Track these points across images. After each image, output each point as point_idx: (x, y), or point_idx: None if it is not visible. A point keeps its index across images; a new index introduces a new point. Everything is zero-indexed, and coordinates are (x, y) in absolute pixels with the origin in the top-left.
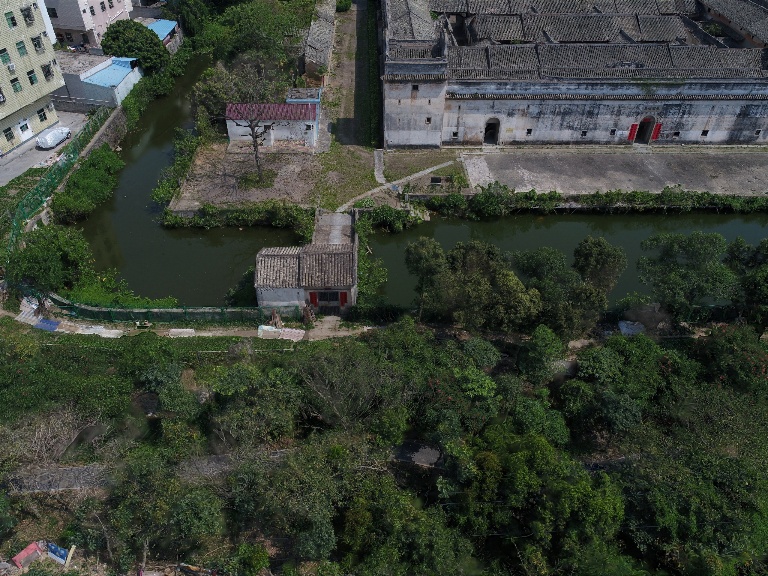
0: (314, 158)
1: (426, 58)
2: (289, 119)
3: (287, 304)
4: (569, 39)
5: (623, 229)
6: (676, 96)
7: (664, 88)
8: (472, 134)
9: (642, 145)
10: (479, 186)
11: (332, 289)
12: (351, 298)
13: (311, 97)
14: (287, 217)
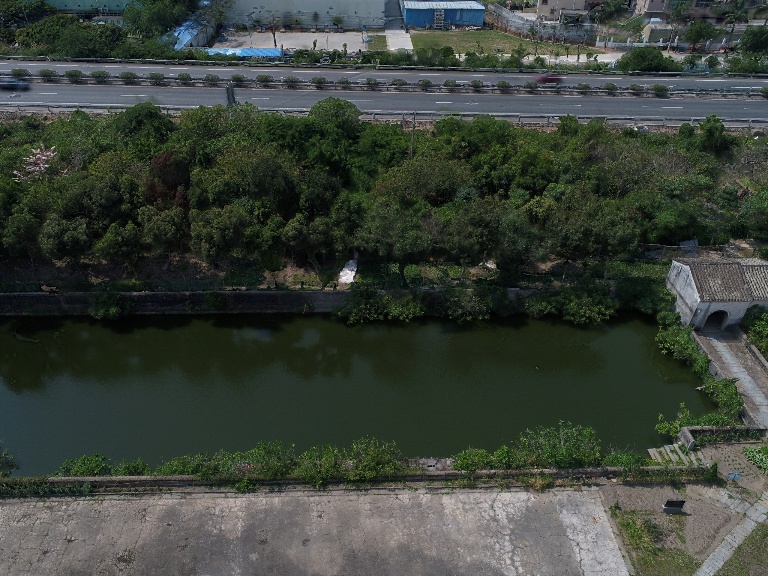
0: None
1: None
2: None
3: None
4: None
5: None
6: None
7: None
8: None
9: None
10: (594, 456)
11: None
12: None
13: None
14: None
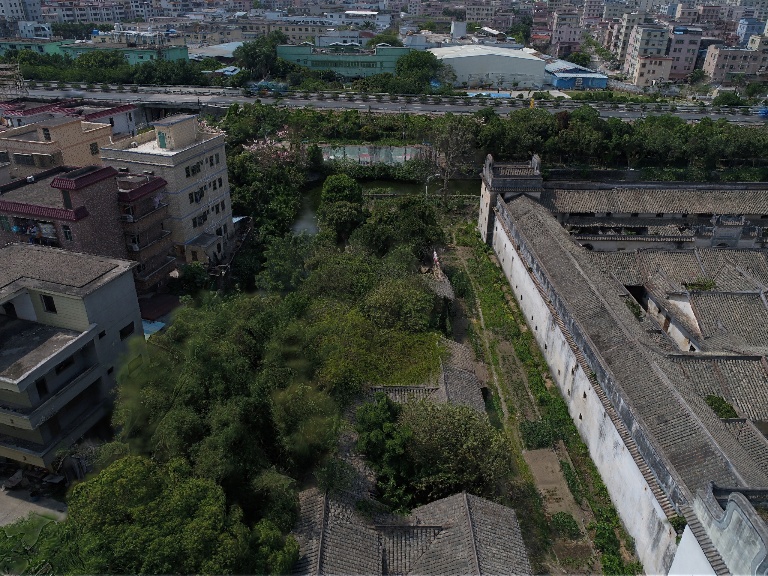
0: None
1: None
2: None
3: None
4: None
5: None
6: None
7: None
8: None
9: None
10: None
11: None
12: None
13: None
14: None
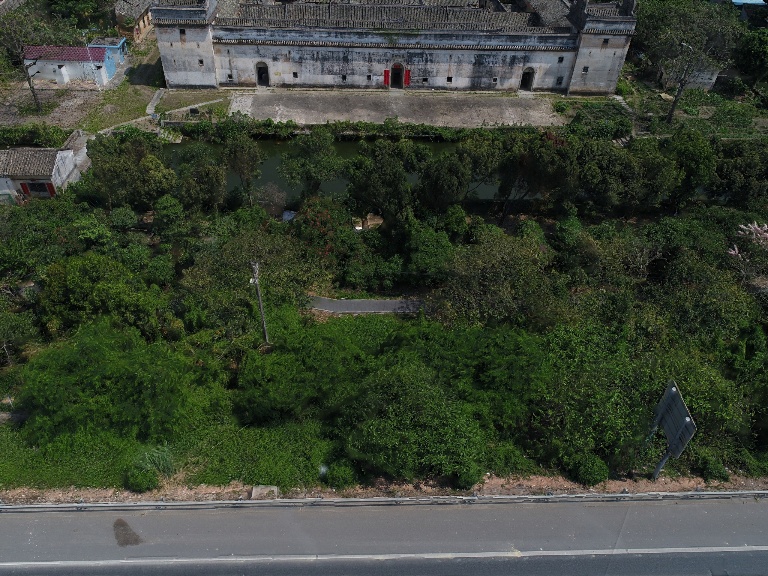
0: (99, 94)
1: (186, 5)
2: (79, 60)
3: (1, 193)
4: (372, 2)
5: (355, 155)
6: (415, 45)
7: (404, 38)
8: (245, 76)
9: (398, 89)
10: (224, 114)
11: (36, 179)
12: (54, 188)
13: (112, 44)
14: (46, 136)
